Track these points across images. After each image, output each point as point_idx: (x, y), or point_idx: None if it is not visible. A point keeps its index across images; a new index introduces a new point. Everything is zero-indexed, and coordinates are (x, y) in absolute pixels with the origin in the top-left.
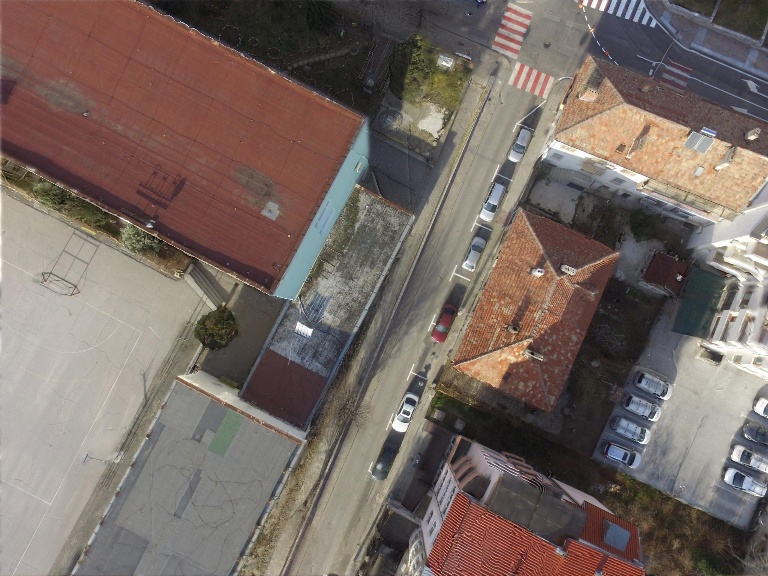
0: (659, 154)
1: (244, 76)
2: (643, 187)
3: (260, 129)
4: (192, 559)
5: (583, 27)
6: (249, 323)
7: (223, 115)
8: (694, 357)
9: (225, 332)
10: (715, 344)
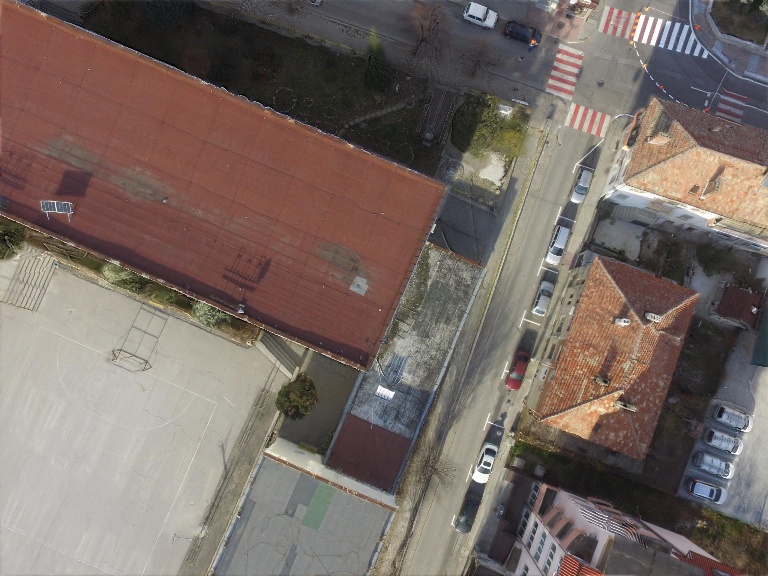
0: (734, 193)
1: (323, 152)
2: (715, 224)
3: (342, 204)
4: None
5: (635, 63)
6: (323, 386)
7: (304, 192)
8: None
9: (309, 403)
10: None
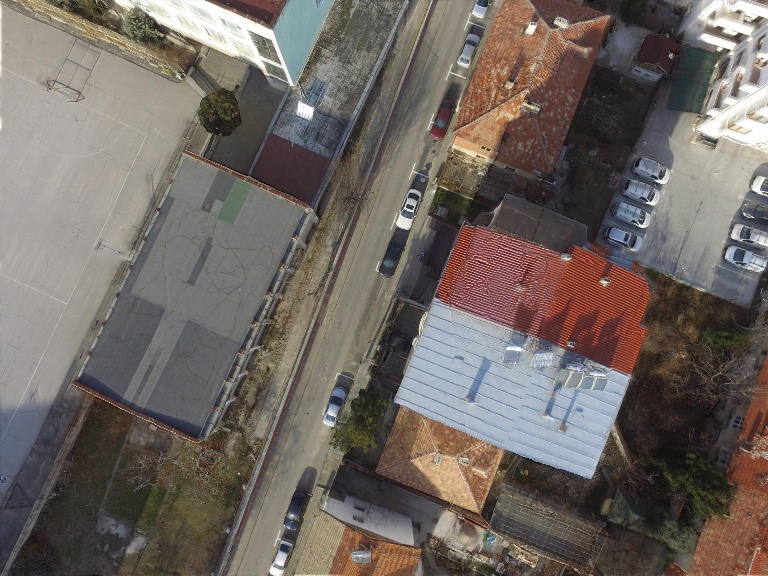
0: None
1: None
2: None
3: None
4: (208, 324)
5: None
6: (251, 123)
7: None
8: (690, 142)
9: (228, 106)
10: (709, 116)
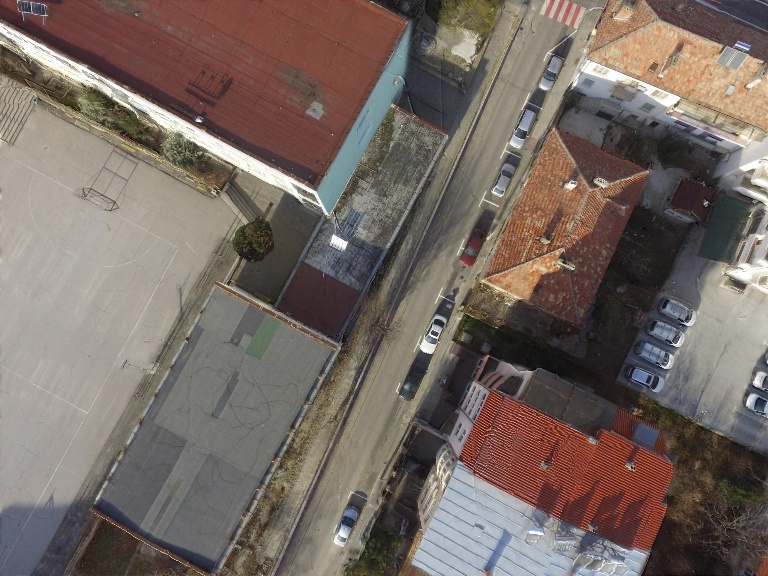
0: (691, 72)
1: None
2: (673, 109)
3: (306, 31)
4: (229, 458)
5: None
6: (283, 242)
7: (270, 17)
8: (718, 285)
9: (263, 240)
10: (740, 268)
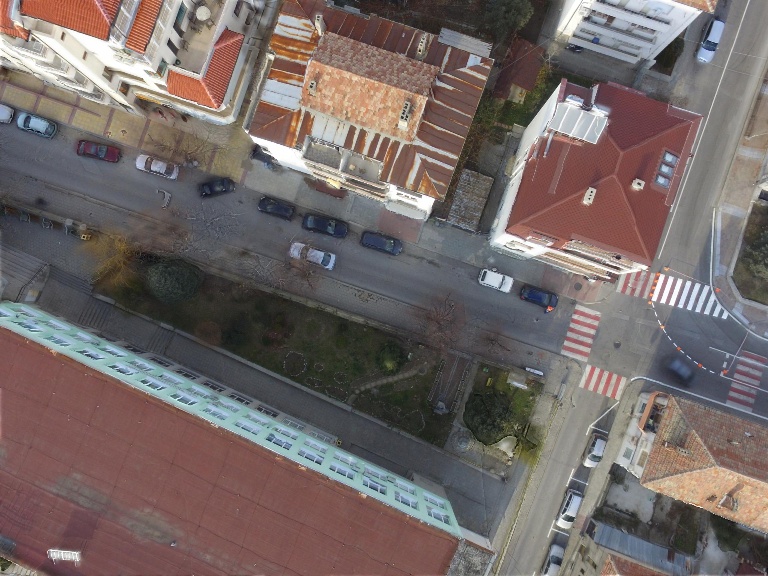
0: (752, 506)
1: (333, 500)
2: None
3: (353, 553)
4: None
5: (653, 323)
6: None
7: (314, 540)
8: None
9: None
10: None
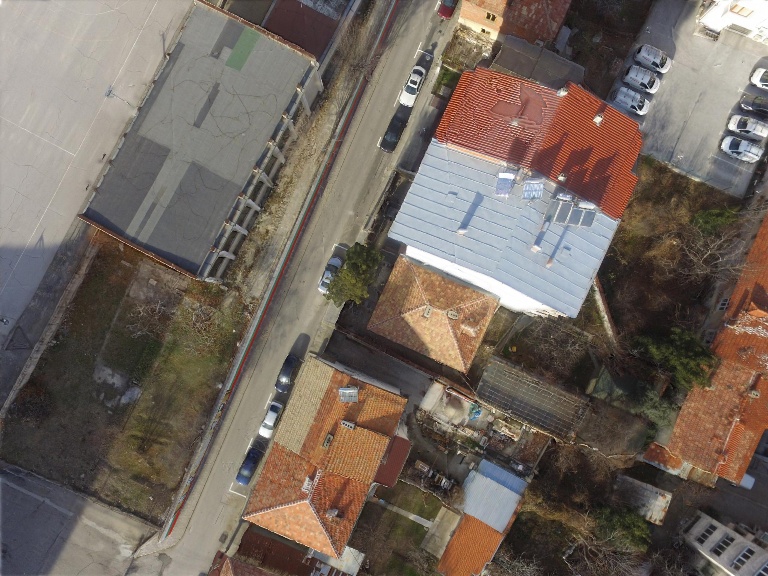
0: None
1: None
2: None
3: None
4: (211, 166)
5: None
6: None
7: None
8: (692, 33)
9: None
10: (713, 2)
